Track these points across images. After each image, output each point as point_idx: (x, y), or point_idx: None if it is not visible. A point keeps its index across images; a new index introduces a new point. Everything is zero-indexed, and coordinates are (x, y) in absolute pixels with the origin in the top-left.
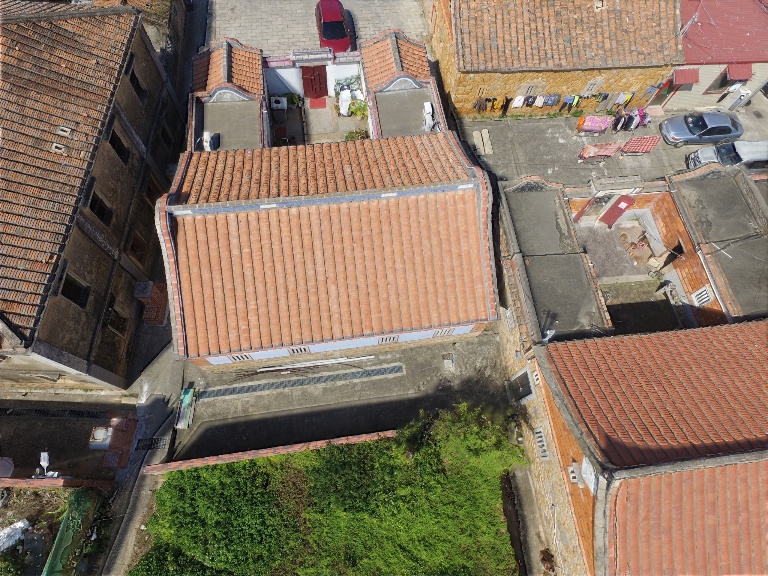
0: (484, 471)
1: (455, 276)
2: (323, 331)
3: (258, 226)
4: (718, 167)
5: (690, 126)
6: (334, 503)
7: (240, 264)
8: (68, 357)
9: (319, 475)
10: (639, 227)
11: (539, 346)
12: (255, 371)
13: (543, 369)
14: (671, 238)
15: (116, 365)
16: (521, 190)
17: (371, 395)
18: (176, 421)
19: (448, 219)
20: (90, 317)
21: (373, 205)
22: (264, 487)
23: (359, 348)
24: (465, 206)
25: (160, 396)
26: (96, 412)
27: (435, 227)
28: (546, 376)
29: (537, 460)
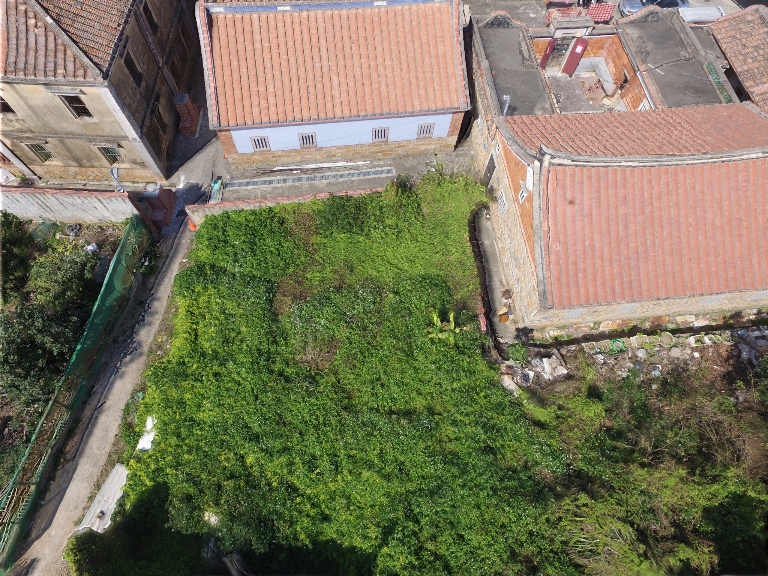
0: (455, 214)
1: (433, 73)
2: (327, 112)
3: (276, 26)
4: (656, 8)
5: (643, 1)
6: (336, 230)
7: (261, 55)
8: (129, 114)
9: (324, 214)
10: (596, 77)
11: (499, 116)
12: (271, 170)
13: (501, 129)
14: (619, 73)
15: (159, 155)
16: (491, 26)
17: (366, 188)
18: (208, 200)
19: (428, 27)
20: (142, 99)
21: (367, 13)
22: (280, 225)
23: (357, 147)
24: (441, 17)
25: (194, 184)
26: (142, 198)
27: (417, 32)
28: (503, 132)
29: (500, 220)
